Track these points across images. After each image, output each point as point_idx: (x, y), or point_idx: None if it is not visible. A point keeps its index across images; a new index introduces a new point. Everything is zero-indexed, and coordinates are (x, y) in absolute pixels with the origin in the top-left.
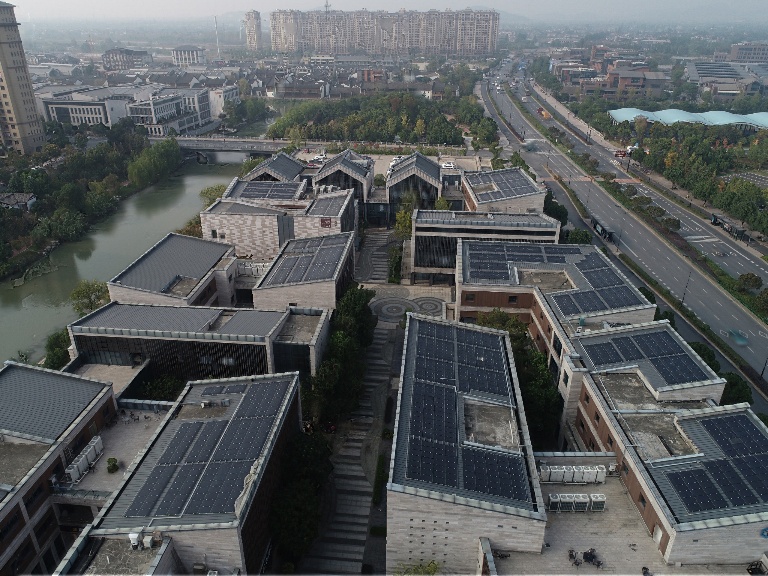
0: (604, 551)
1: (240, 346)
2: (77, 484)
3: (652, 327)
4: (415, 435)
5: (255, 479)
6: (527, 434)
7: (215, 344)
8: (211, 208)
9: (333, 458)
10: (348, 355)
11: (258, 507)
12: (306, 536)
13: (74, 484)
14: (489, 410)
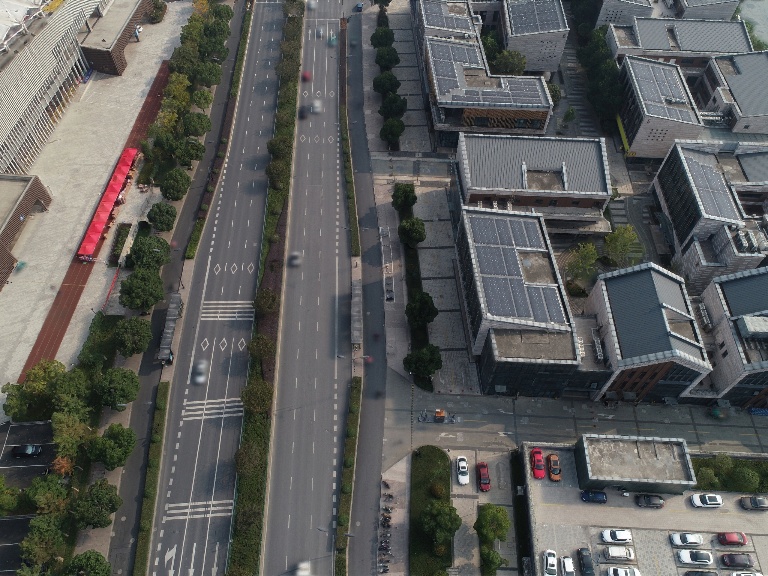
0: None
1: None
2: None
3: None
4: None
5: None
6: None
7: None
8: None
9: None
10: None
11: None
12: None
13: None
14: None
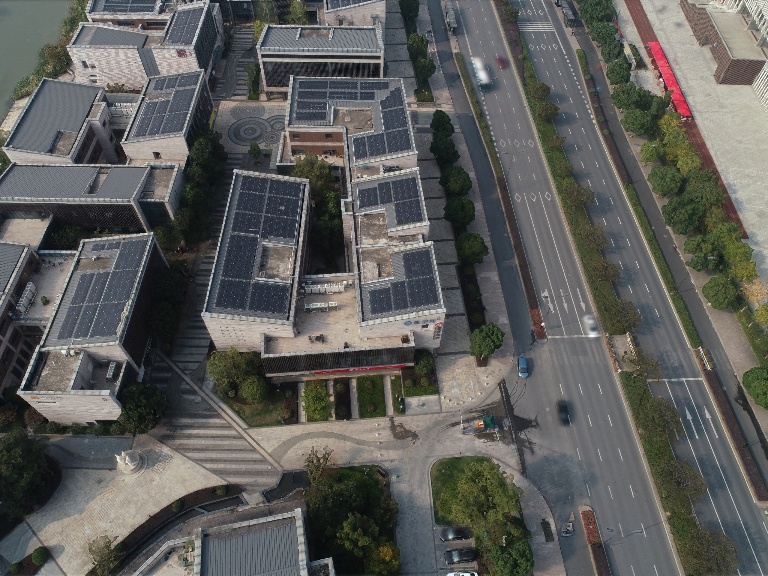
0: (330, 334)
1: (114, 205)
2: (26, 314)
3: (408, 173)
4: (224, 277)
5: (127, 315)
6: (298, 268)
7: (96, 205)
8: (76, 38)
9: (195, 272)
10: (197, 201)
11: (134, 325)
12: (169, 334)
13: (24, 314)
14: (279, 250)
